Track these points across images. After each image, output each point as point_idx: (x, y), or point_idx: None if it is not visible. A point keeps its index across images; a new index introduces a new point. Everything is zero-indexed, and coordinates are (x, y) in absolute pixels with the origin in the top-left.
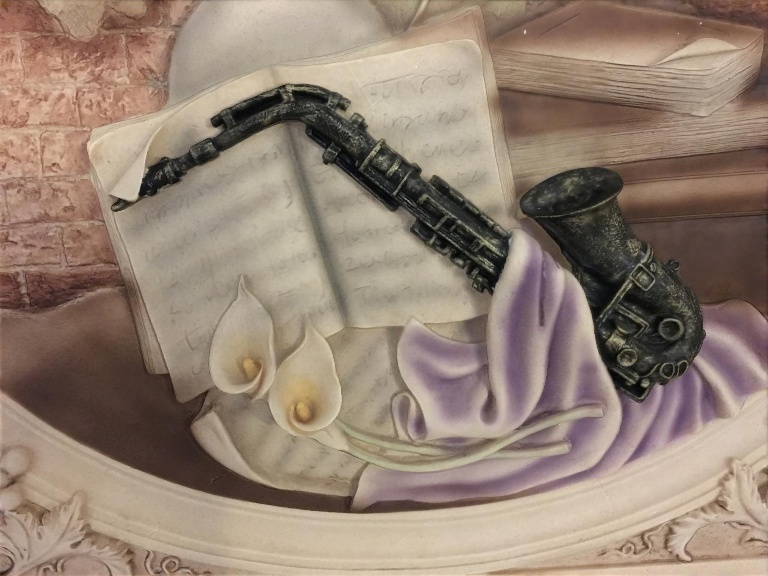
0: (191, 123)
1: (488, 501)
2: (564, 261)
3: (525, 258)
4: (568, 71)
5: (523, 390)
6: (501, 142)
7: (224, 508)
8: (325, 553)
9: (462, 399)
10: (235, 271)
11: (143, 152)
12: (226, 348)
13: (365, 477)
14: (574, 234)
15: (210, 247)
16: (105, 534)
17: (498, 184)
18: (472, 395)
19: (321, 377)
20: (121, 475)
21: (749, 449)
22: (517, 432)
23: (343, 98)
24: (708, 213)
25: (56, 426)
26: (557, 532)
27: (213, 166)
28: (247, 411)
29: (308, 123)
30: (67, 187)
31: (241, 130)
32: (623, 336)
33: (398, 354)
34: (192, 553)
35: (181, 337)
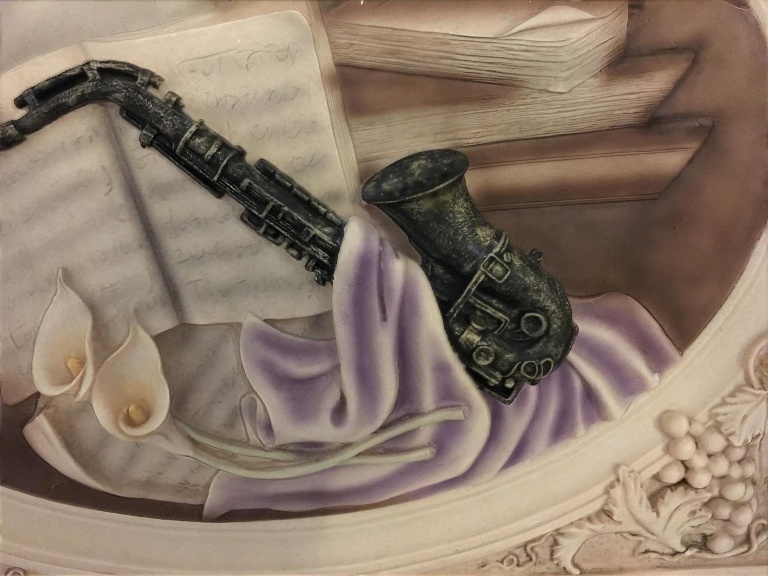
0: None
1: (354, 510)
2: (413, 251)
3: (357, 248)
4: (411, 44)
5: (375, 391)
6: (341, 123)
7: (70, 516)
8: (181, 564)
9: (313, 401)
10: (54, 264)
11: None
12: (50, 346)
13: (216, 484)
14: (416, 221)
15: (27, 238)
16: None
17: (339, 168)
18: (323, 396)
19: (150, 377)
20: None
21: (637, 454)
22: (375, 436)
23: (155, 75)
24: (578, 198)
25: None
26: (432, 543)
27: (23, 151)
28: (84, 414)
29: (117, 103)
30: None
31: (44, 111)
32: (478, 332)
33: (241, 352)
34: (35, 564)
35: (5, 335)
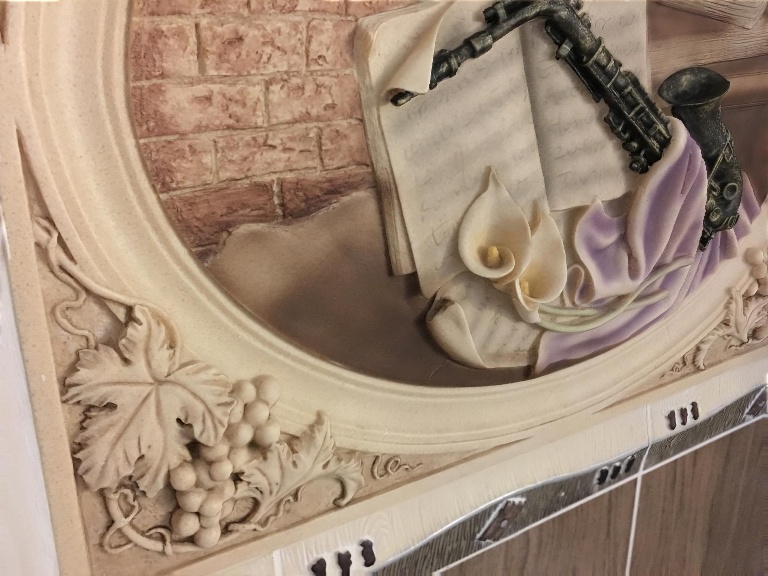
0: (460, 16)
1: (608, 349)
2: None
3: (686, 138)
4: None
5: (653, 250)
6: (647, 45)
7: (434, 399)
8: (504, 421)
9: (611, 264)
10: (483, 163)
11: (430, 43)
12: (472, 239)
13: (543, 345)
14: (700, 119)
15: (464, 141)
16: (348, 448)
17: (646, 80)
18: (618, 260)
19: (545, 255)
20: (354, 386)
21: (737, 280)
22: (641, 286)
23: None
24: (736, 104)
25: (306, 345)
26: (641, 365)
27: (474, 60)
28: (466, 300)
29: (556, 20)
30: (331, 82)
31: (512, 24)
32: (714, 198)
33: (576, 231)
34: (416, 447)
35: (428, 234)
